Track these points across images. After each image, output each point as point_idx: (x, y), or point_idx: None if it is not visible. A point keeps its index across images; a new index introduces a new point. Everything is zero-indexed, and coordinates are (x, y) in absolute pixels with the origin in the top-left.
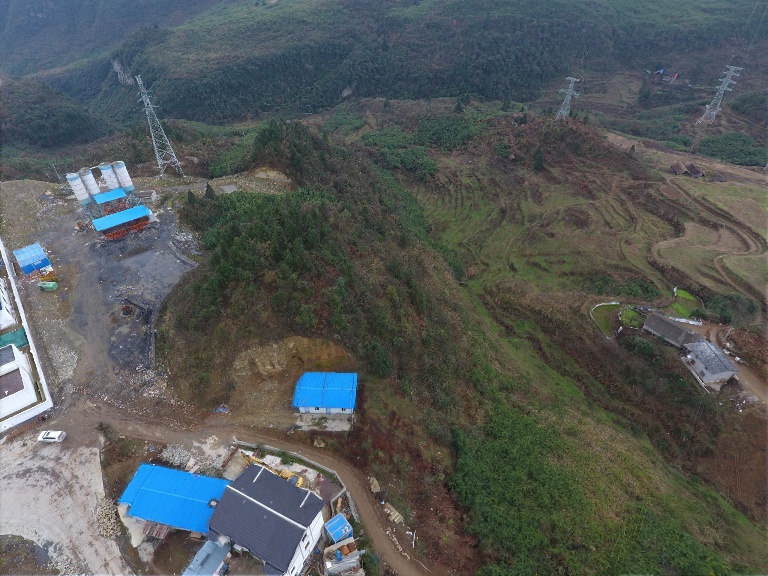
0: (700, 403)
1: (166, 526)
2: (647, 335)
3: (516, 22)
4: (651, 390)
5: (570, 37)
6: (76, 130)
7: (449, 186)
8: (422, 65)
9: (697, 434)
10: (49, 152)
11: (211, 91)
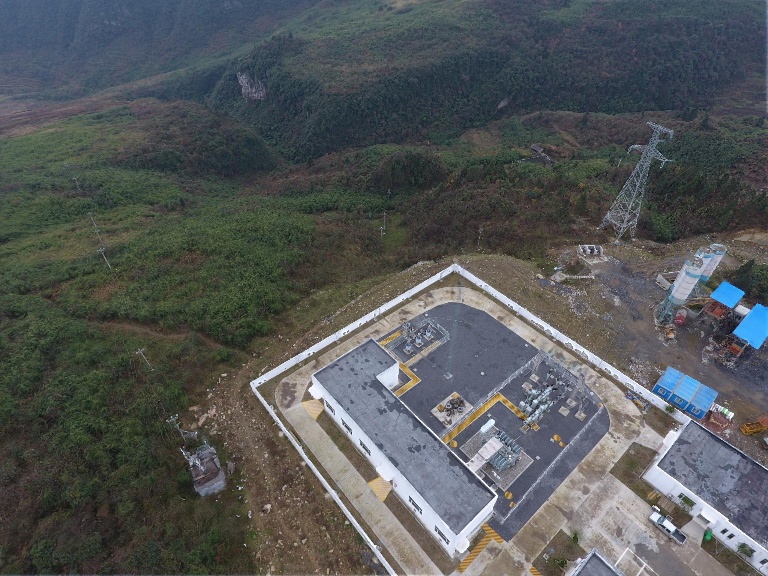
0: None
1: None
2: None
3: (690, 24)
4: None
5: (745, 39)
6: (254, 156)
7: None
8: (589, 73)
9: None
10: (234, 182)
11: (373, 107)
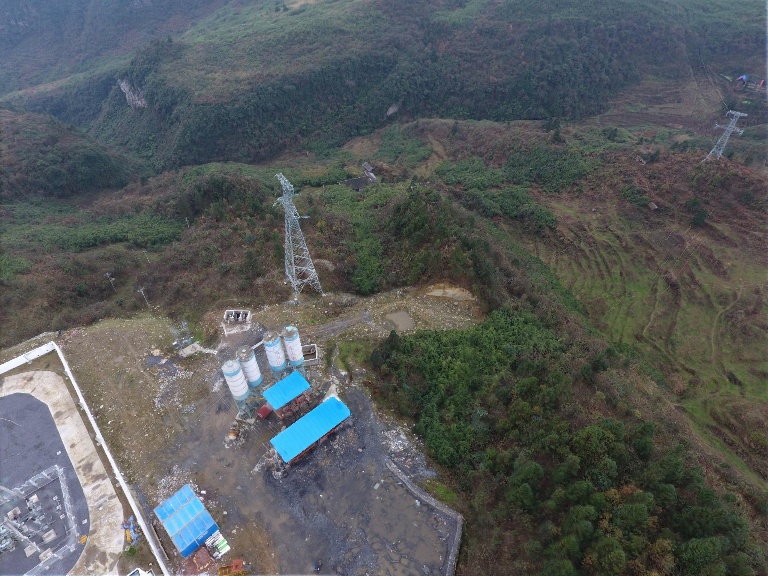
0: None
1: None
2: None
3: (581, 26)
4: None
5: (639, 41)
6: (96, 174)
7: (580, 244)
8: (478, 77)
9: None
10: (68, 204)
11: (244, 116)
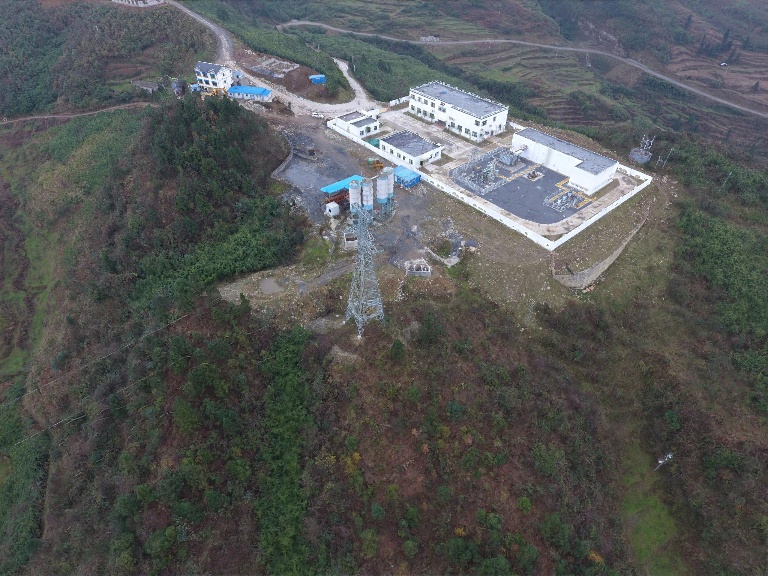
0: None
1: None
2: None
3: None
4: None
5: None
6: None
7: None
8: None
9: None
10: None
11: None
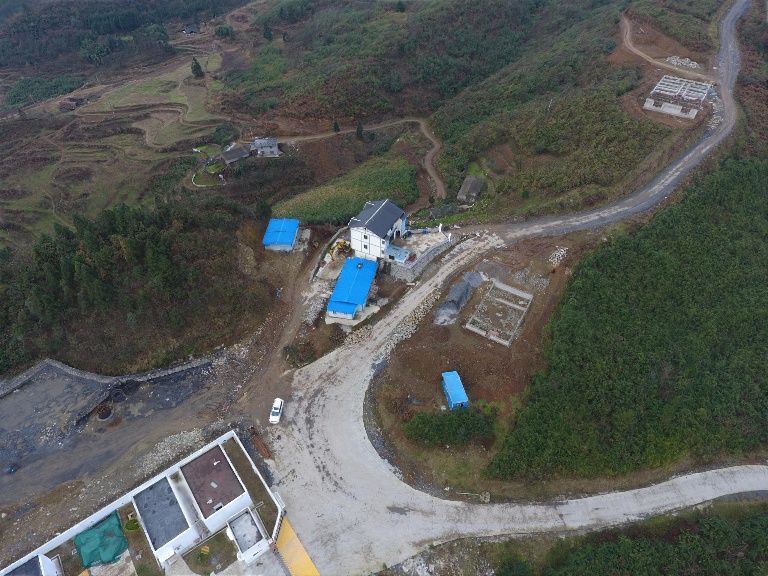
0: (288, 160)
1: (371, 286)
2: (233, 165)
3: None
4: (270, 179)
5: None
6: None
7: None
8: None
9: (302, 173)
10: None
11: None
